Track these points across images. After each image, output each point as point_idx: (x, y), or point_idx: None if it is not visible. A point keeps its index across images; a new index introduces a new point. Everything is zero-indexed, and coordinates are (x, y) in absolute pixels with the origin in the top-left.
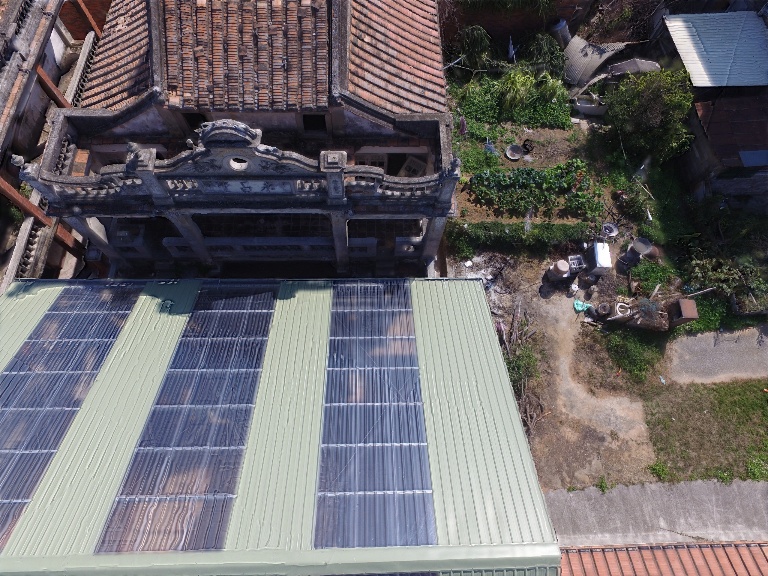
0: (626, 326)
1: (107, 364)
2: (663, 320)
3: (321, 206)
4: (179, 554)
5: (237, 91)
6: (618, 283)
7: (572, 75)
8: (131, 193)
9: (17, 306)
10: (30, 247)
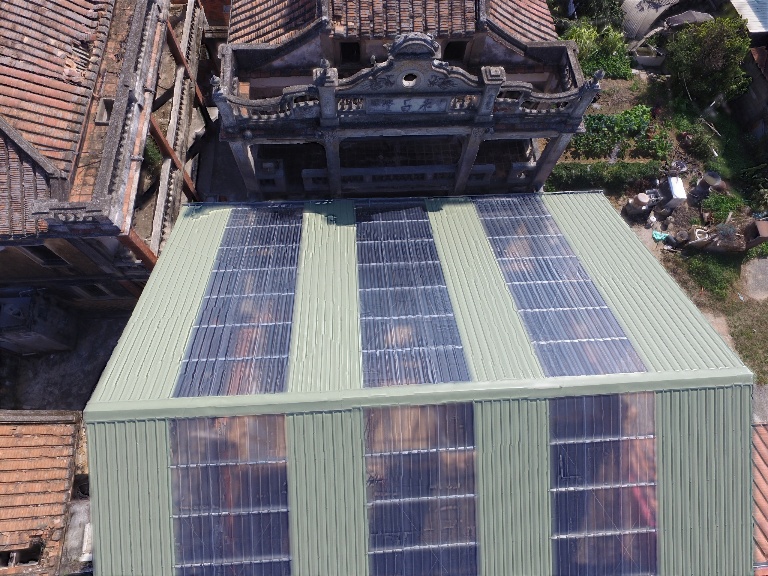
0: (704, 250)
1: (301, 262)
2: (741, 241)
3: (468, 124)
4: (434, 385)
5: (395, 20)
6: (690, 214)
7: (630, 29)
8: (299, 116)
9: (197, 224)
10: (169, 187)
